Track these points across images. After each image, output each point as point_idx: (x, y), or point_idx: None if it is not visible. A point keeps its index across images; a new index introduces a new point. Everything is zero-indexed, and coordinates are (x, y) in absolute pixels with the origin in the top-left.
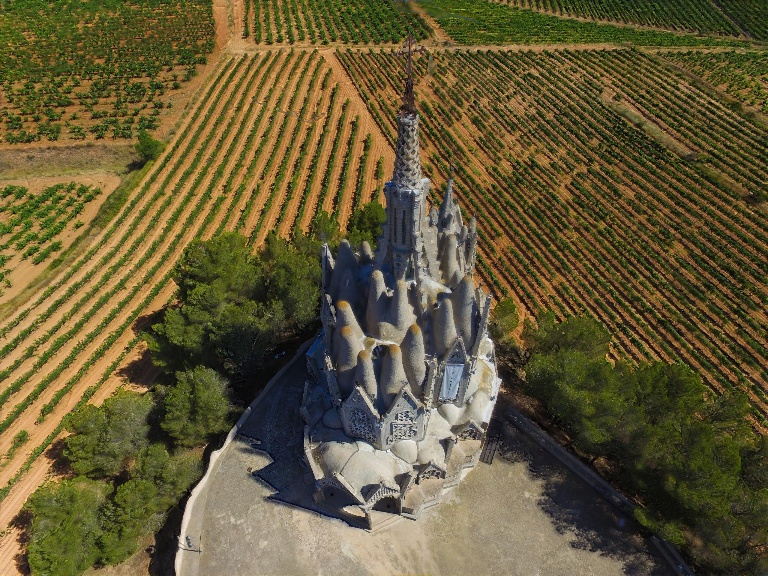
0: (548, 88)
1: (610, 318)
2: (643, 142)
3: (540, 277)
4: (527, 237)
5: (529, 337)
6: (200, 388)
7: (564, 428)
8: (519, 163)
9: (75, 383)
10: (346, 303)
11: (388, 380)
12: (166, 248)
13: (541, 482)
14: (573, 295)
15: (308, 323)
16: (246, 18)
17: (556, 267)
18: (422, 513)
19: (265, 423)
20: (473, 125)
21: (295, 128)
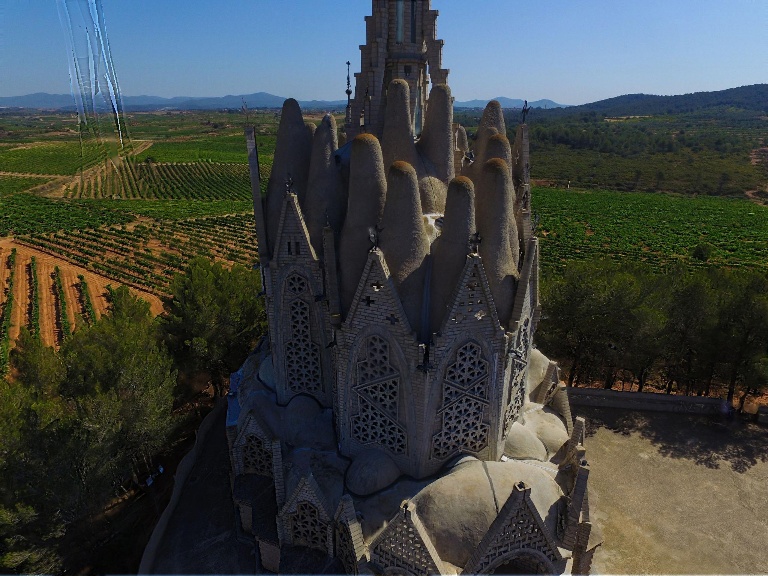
0: None
1: None
2: None
3: None
4: None
5: None
6: None
7: (590, 378)
8: None
9: None
10: None
11: (498, 244)
12: None
13: (636, 436)
14: None
15: (169, 433)
16: None
17: None
18: None
19: None
20: (230, 261)
21: None
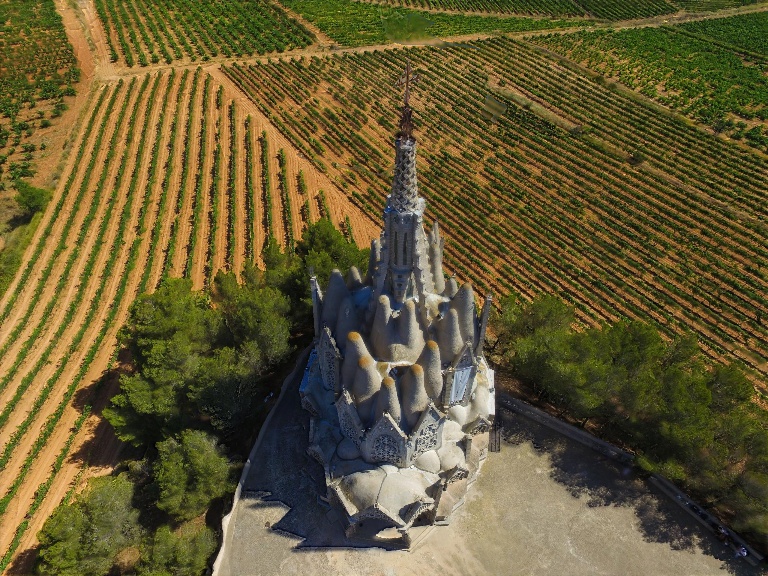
0: (439, 81)
1: (553, 289)
2: (535, 122)
3: (483, 263)
4: (460, 227)
5: (495, 323)
6: (195, 454)
7: (553, 401)
8: (434, 157)
9: (19, 484)
10: (357, 334)
11: (412, 400)
12: (86, 307)
13: (547, 456)
14: (517, 274)
15: (284, 357)
16: (109, 40)
17: (494, 251)
18: (452, 517)
19: (269, 472)
20: (380, 126)
21: (199, 153)
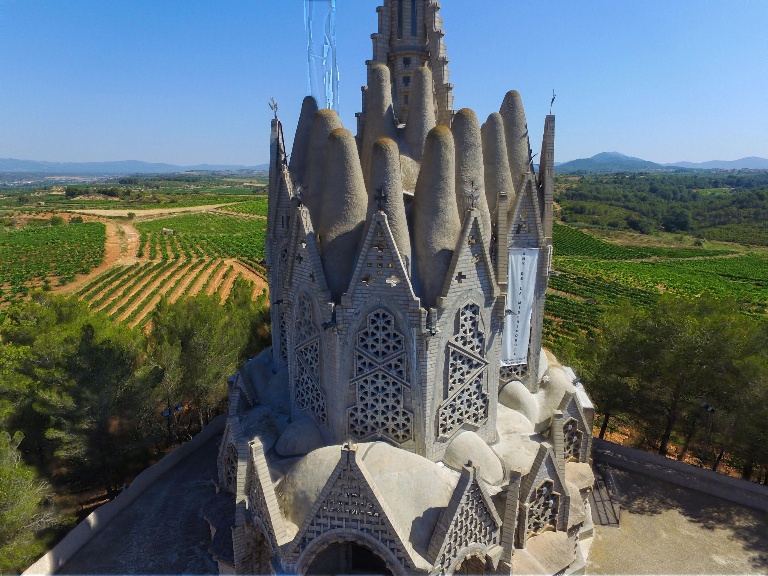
0: None
1: None
2: None
3: None
4: None
5: None
6: None
7: (687, 451)
8: None
9: None
10: None
11: (434, 214)
12: None
13: (723, 534)
14: None
15: (222, 395)
16: (141, 248)
17: None
18: None
19: (126, 548)
20: None
21: None
